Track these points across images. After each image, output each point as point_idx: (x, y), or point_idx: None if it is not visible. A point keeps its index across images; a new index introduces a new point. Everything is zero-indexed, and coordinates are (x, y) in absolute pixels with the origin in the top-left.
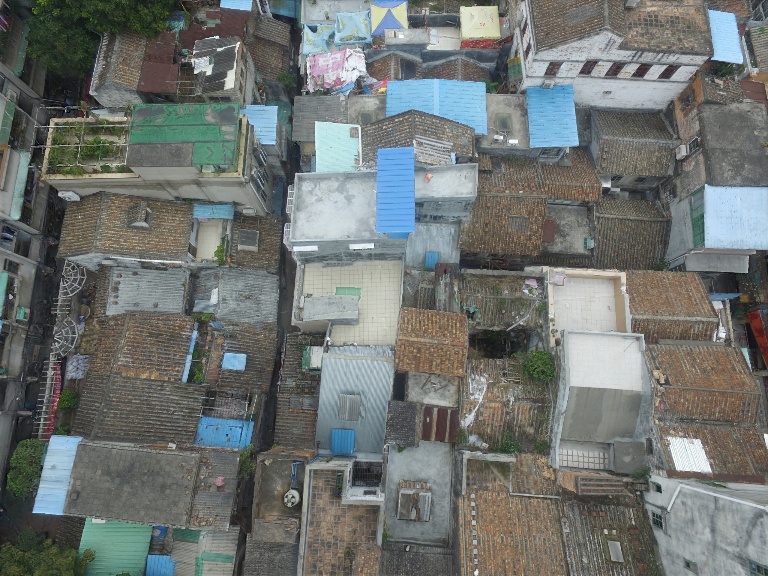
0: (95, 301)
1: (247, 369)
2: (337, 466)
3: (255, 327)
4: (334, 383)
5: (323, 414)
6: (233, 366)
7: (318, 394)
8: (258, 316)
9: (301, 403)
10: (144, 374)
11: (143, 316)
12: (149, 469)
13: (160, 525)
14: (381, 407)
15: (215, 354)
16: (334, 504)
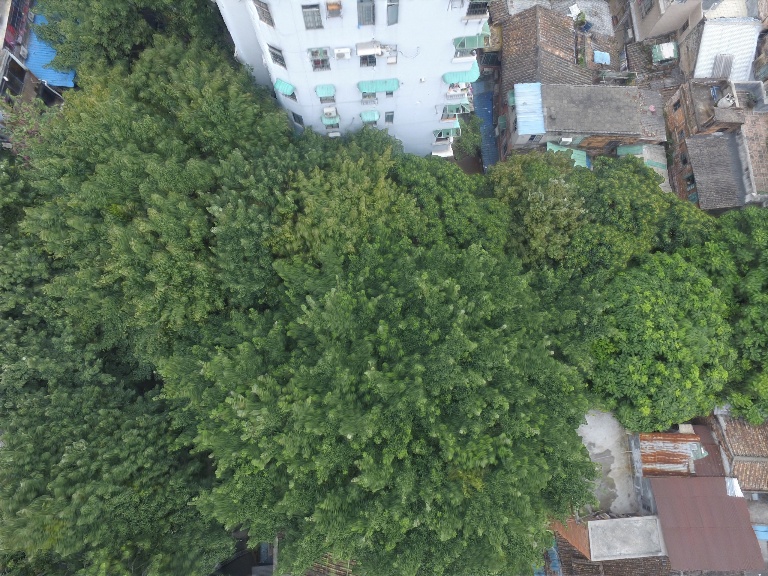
0: (490, 10)
1: (607, 67)
2: (754, 81)
3: (604, 38)
4: (710, 48)
5: (698, 77)
6: (602, 60)
7: (676, 75)
8: (604, 30)
9: (663, 84)
10: (556, 52)
11: (545, 9)
12: (603, 97)
13: (623, 133)
14: (744, 68)
15: (588, 50)
16: (748, 113)
